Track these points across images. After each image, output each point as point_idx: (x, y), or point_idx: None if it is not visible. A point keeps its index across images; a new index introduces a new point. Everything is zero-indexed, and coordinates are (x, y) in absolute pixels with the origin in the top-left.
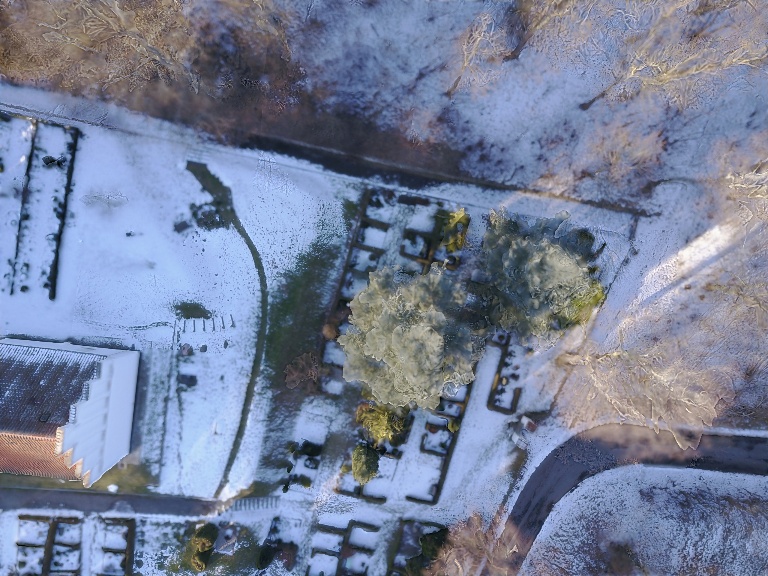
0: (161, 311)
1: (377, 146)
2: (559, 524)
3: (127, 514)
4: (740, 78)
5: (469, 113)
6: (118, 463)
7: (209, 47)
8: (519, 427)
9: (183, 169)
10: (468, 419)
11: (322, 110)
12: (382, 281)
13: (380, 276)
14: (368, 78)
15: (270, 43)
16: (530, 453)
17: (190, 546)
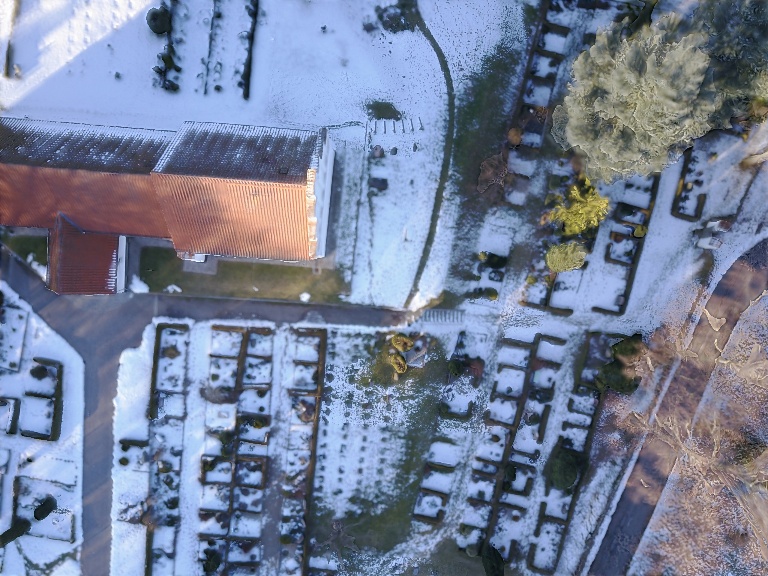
0: (353, 110)
1: None
2: (748, 332)
3: (319, 325)
4: None
5: None
6: (312, 268)
7: None
8: (707, 231)
9: None
10: (652, 227)
11: None
12: (611, 34)
13: (608, 30)
14: None
15: None
16: (716, 260)
17: (380, 359)
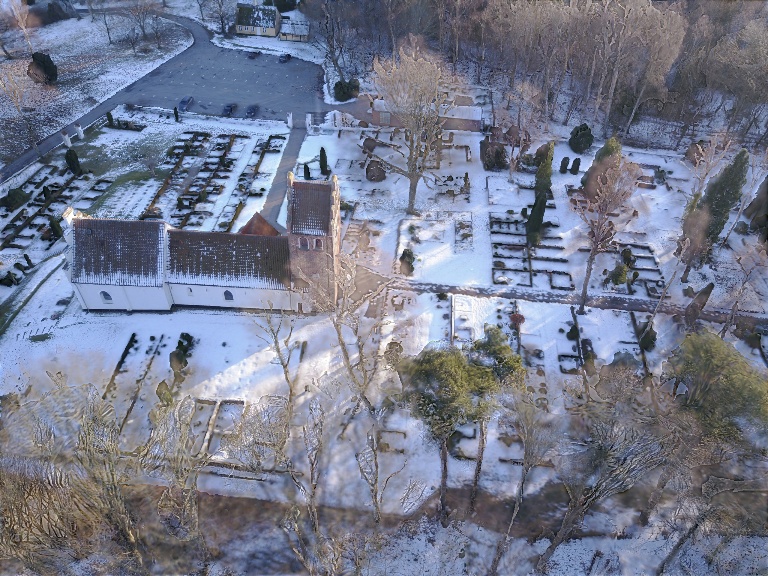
0: None
1: None
2: None
3: None
4: None
5: None
6: None
7: None
8: None
9: None
10: None
11: None
12: None
13: None
14: None
15: None
16: None
17: None
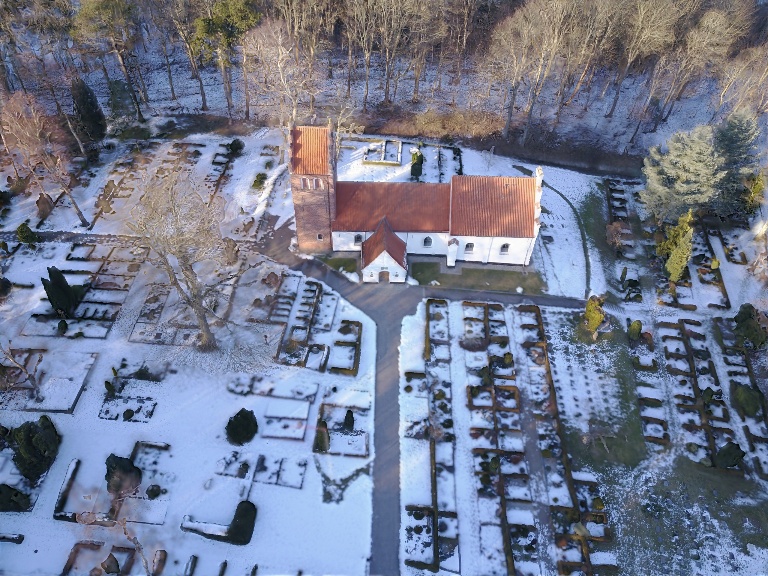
0: None
1: (606, 158)
2: None
3: None
4: (764, 125)
5: (645, 147)
6: (522, 272)
7: (514, 127)
8: None
9: (511, 168)
10: (721, 268)
11: (573, 147)
12: None
13: None
14: (591, 136)
15: (541, 127)
16: None
17: (580, 326)
